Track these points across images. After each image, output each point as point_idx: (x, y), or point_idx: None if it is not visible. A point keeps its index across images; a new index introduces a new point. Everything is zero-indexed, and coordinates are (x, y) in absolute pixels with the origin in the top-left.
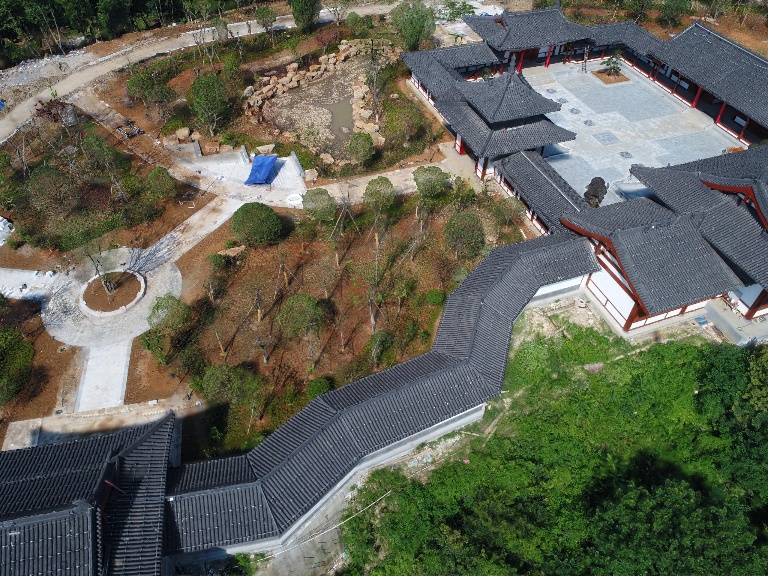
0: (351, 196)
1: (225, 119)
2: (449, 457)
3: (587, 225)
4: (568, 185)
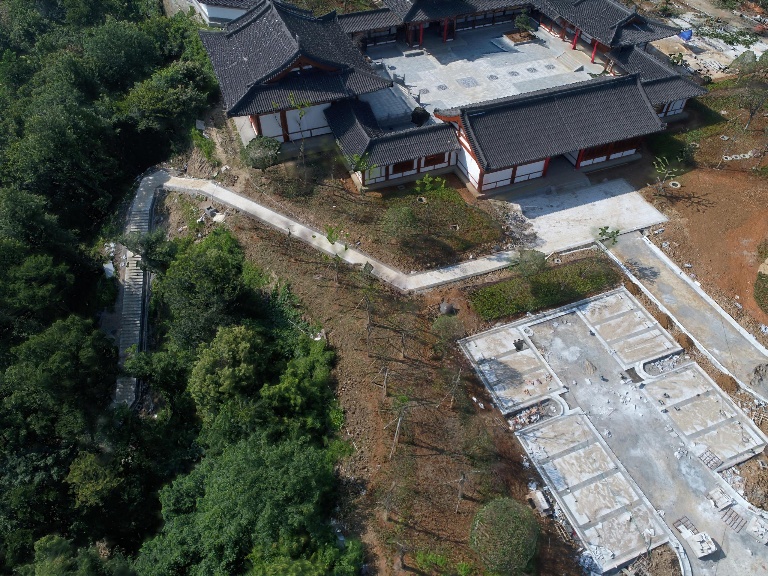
0: None
1: None
2: None
3: (291, 7)
4: (359, 29)
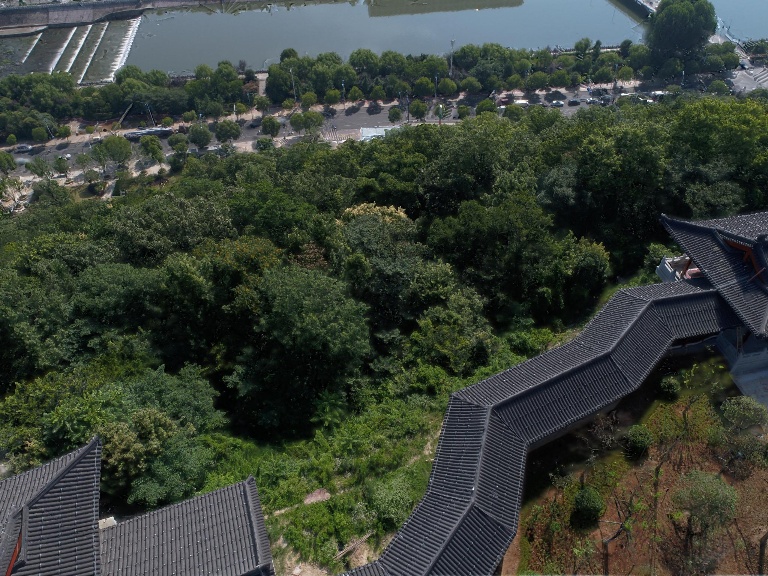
0: None
1: None
2: None
3: None
4: None
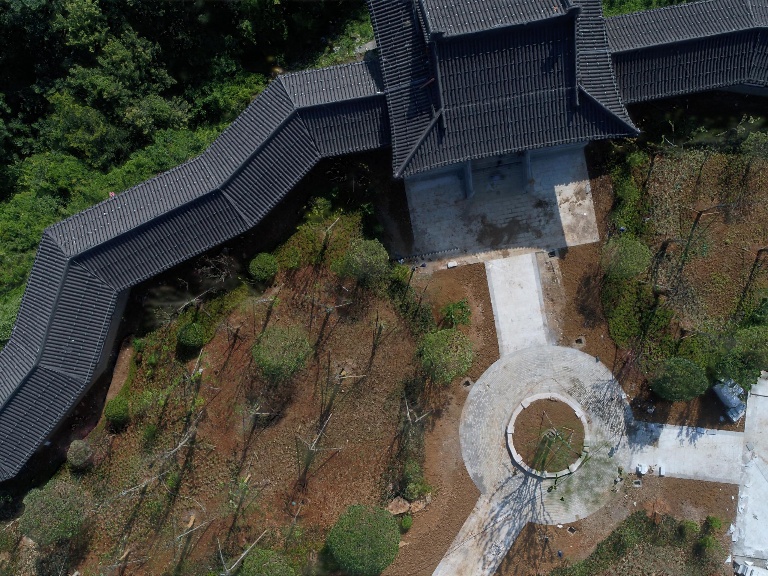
0: None
1: None
2: None
3: None
4: None
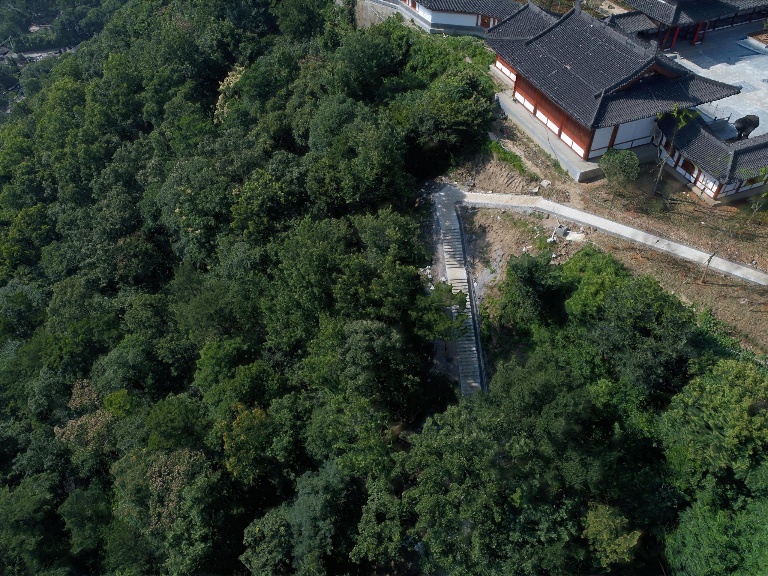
0: None
1: None
2: None
3: None
4: None
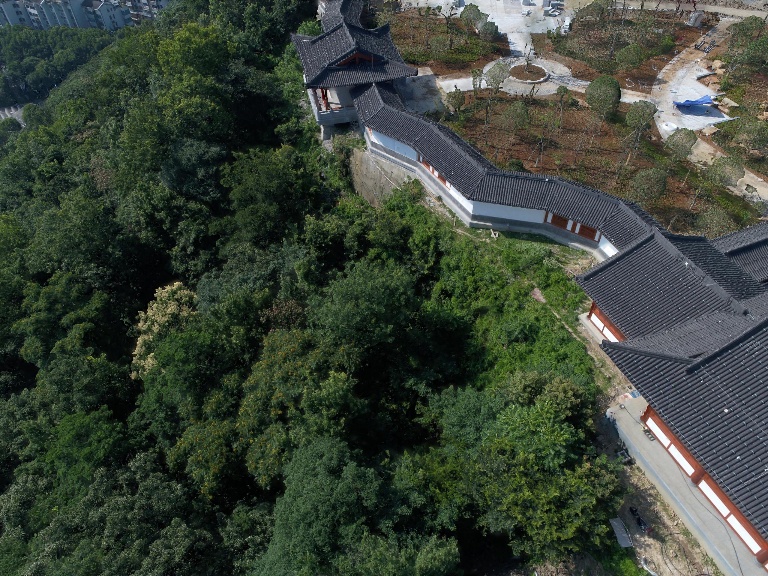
0: (696, 155)
1: (758, 79)
2: (435, 213)
3: None
4: None
